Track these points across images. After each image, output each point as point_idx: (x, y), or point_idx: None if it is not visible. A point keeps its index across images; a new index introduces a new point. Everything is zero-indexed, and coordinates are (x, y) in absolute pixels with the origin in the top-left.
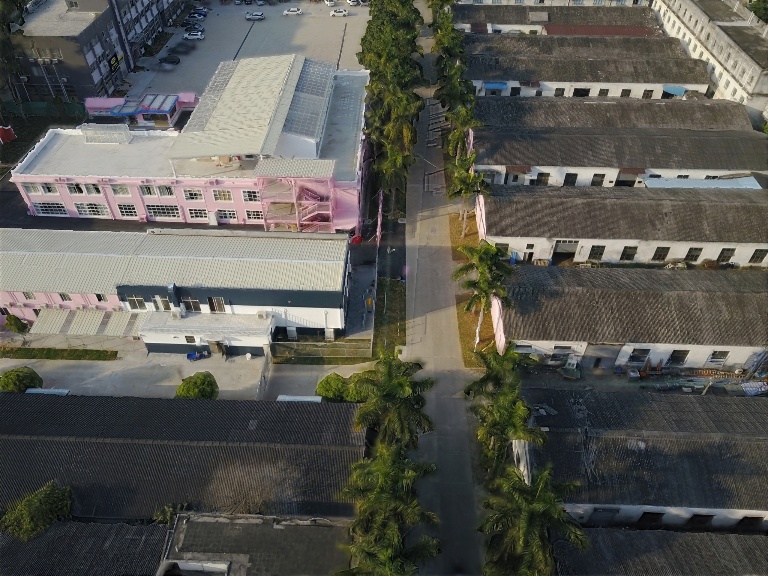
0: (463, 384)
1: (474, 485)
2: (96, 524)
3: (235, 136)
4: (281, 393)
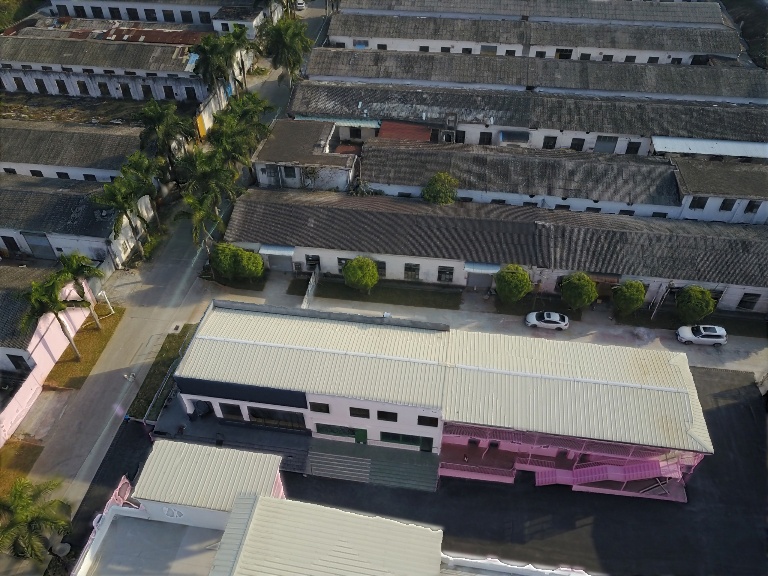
0: (138, 294)
1: (174, 233)
2: (403, 183)
3: (305, 575)
4: (296, 301)
